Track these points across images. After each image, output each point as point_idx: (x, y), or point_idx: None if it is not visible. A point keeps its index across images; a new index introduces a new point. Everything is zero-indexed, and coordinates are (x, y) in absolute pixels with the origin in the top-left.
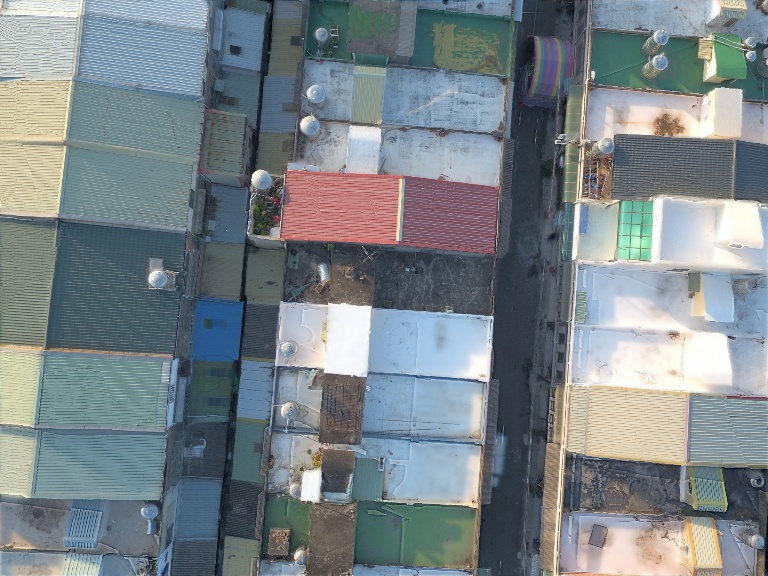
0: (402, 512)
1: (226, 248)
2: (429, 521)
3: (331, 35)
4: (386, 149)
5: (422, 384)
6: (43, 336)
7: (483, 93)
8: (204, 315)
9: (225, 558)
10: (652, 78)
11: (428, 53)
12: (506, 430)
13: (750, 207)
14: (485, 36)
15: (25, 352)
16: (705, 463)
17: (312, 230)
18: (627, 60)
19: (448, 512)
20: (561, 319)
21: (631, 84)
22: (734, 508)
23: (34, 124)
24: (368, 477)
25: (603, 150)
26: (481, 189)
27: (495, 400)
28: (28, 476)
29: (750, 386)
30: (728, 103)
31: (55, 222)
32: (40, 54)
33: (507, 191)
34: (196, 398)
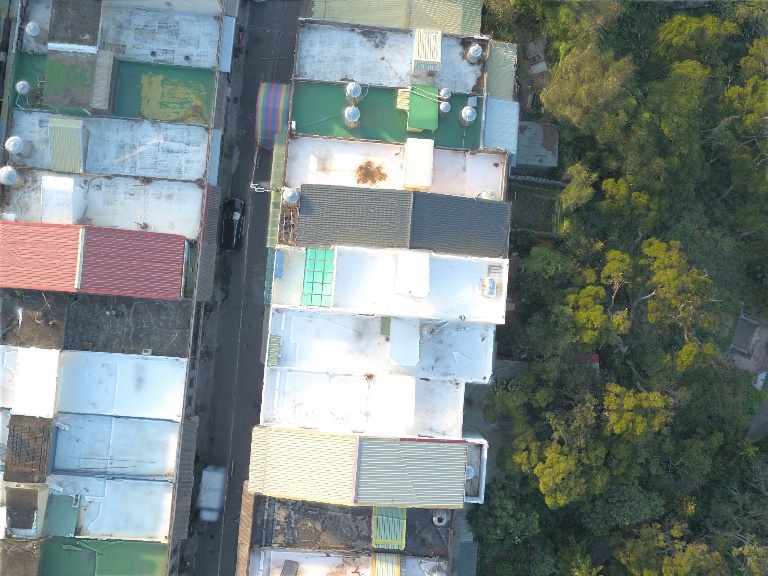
0: (96, 547)
1: None
2: (122, 556)
3: (39, 87)
4: (91, 196)
5: (120, 423)
6: None
7: (189, 142)
8: None
9: None
10: (354, 127)
11: (135, 104)
12: (235, 464)
13: (421, 256)
14: (192, 87)
15: None
16: (374, 503)
17: None
18: (332, 110)
19: (141, 547)
20: None
21: (335, 133)
22: (425, 544)
23: None
24: (62, 513)
25: (287, 200)
26: (166, 237)
27: (192, 439)
28: None
29: (444, 426)
30: (418, 153)
31: None
32: None
33: (212, 236)
34: None
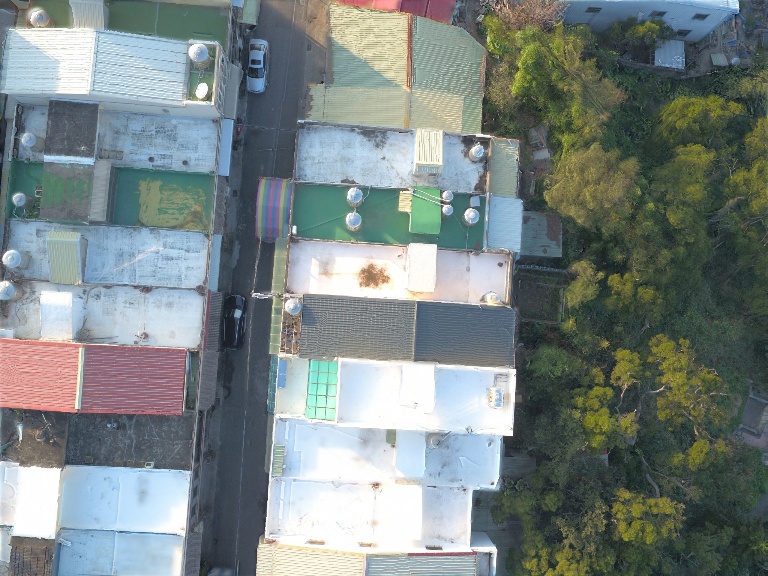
0: None
1: None
2: None
3: (36, 196)
4: (90, 306)
5: (123, 538)
6: None
7: (188, 248)
8: None
9: None
10: (355, 230)
11: (134, 210)
12: (241, 565)
13: (426, 369)
14: (191, 192)
15: None
16: None
17: None
18: (333, 212)
19: None
20: (265, 470)
21: (337, 235)
22: None
23: None
24: None
25: (289, 311)
26: (167, 352)
27: (197, 552)
28: None
29: (452, 533)
30: (421, 258)
31: None
32: None
33: (213, 344)
34: None
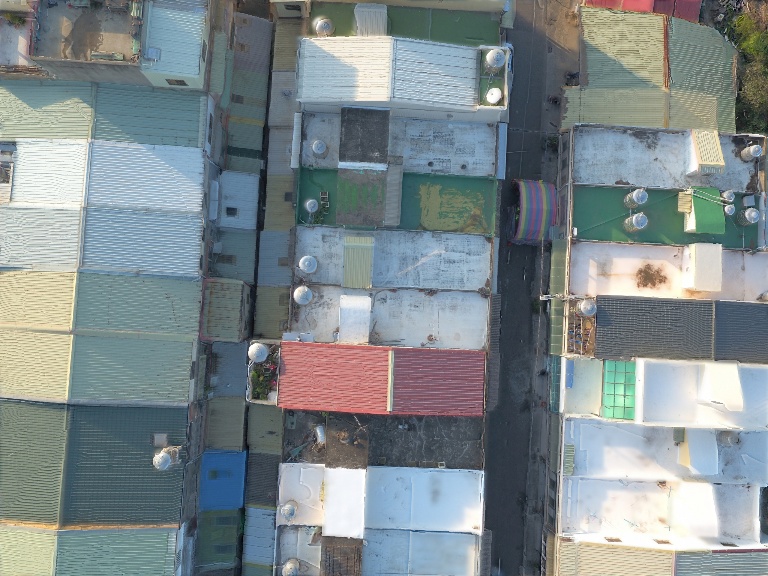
0: None
1: (228, 403)
2: None
3: (322, 202)
4: (377, 310)
5: (417, 537)
6: (56, 515)
7: (469, 251)
8: (208, 467)
9: None
10: (633, 231)
11: (415, 215)
12: (502, 563)
13: (730, 368)
14: (470, 195)
15: (40, 533)
16: None
17: (307, 400)
18: (609, 213)
19: None
20: (550, 469)
21: (613, 236)
22: None
23: (43, 311)
24: None
25: (585, 312)
26: (468, 354)
27: (488, 550)
28: None
29: (737, 530)
30: (708, 258)
31: (64, 406)
32: (46, 246)
33: (495, 345)
34: (203, 548)
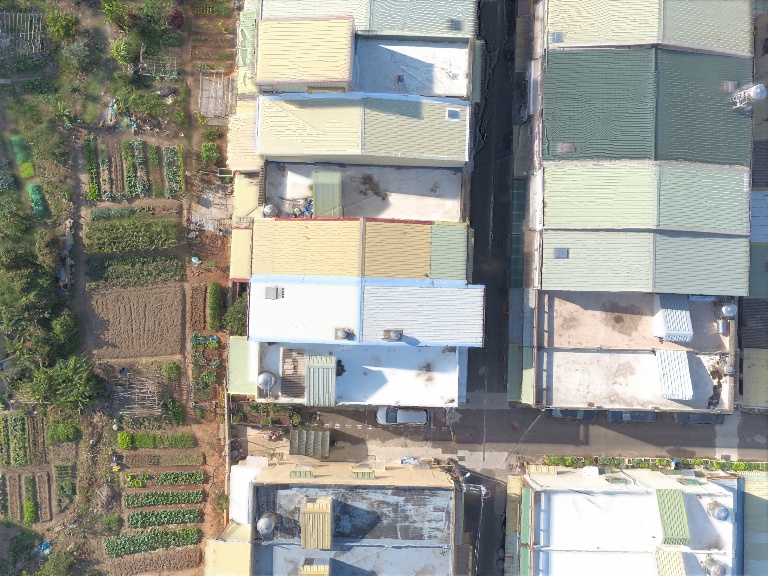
0: None
1: None
2: None
3: None
4: None
5: None
6: None
7: None
8: None
9: (745, 368)
10: None
11: None
12: None
13: None
14: None
15: (642, 163)
16: None
17: None
18: None
19: None
20: None
21: None
22: None
23: None
24: None
25: None
26: None
27: None
28: (647, 273)
29: None
30: None
31: (652, 49)
32: None
33: None
34: None
